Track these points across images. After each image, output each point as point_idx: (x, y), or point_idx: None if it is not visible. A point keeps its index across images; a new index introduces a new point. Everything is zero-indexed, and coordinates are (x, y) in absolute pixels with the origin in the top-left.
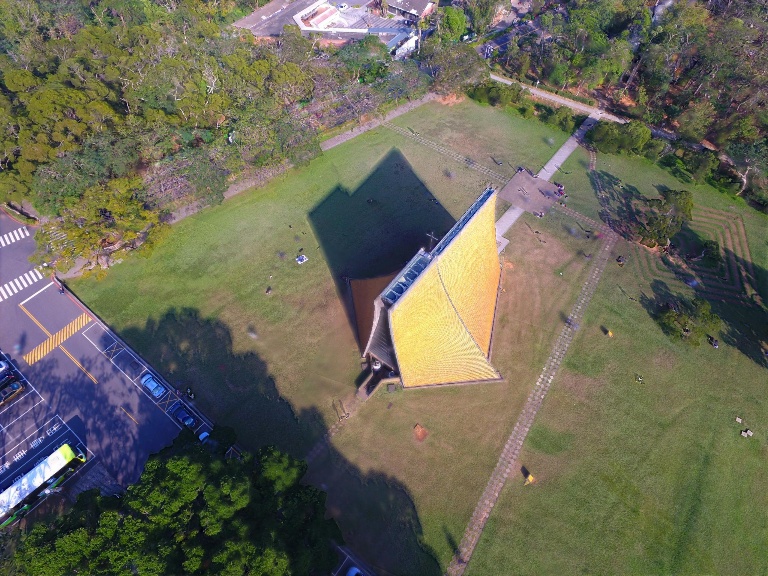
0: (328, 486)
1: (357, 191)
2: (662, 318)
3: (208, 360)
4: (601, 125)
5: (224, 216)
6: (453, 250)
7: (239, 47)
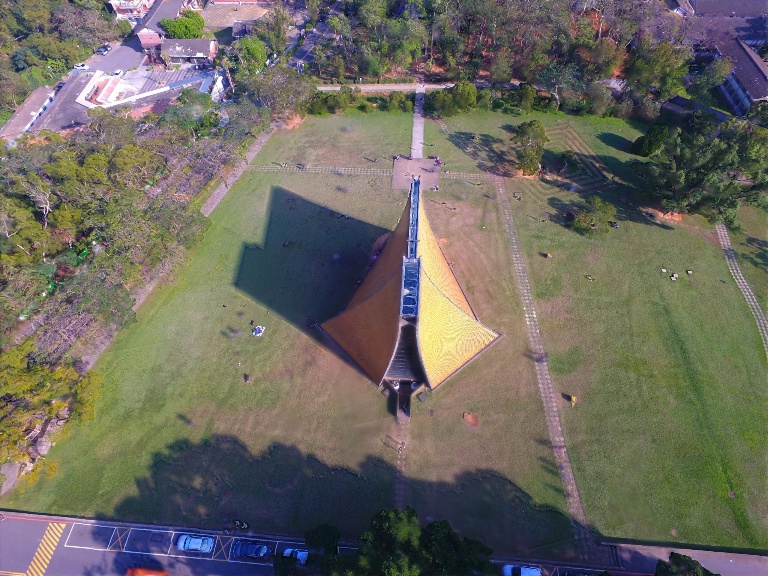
0: (433, 516)
1: (267, 241)
2: (574, 224)
3: (235, 481)
4: (435, 95)
5: (145, 332)
6: (418, 246)
7: (50, 151)
